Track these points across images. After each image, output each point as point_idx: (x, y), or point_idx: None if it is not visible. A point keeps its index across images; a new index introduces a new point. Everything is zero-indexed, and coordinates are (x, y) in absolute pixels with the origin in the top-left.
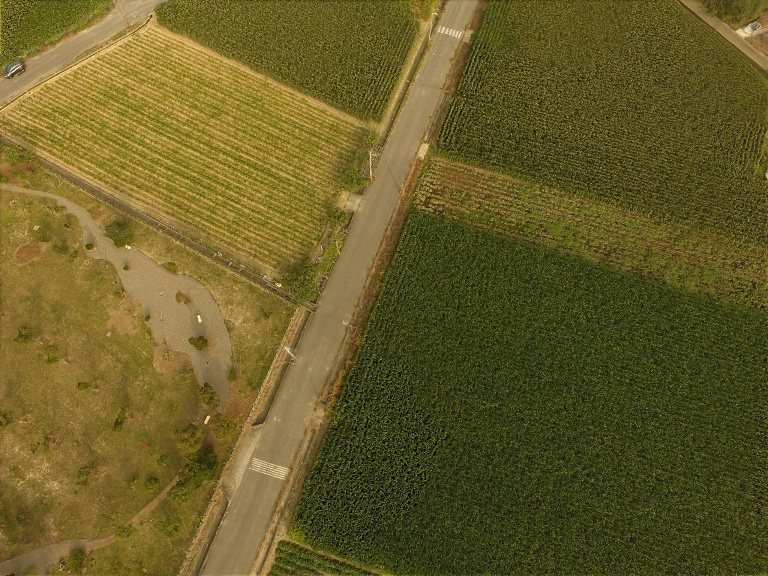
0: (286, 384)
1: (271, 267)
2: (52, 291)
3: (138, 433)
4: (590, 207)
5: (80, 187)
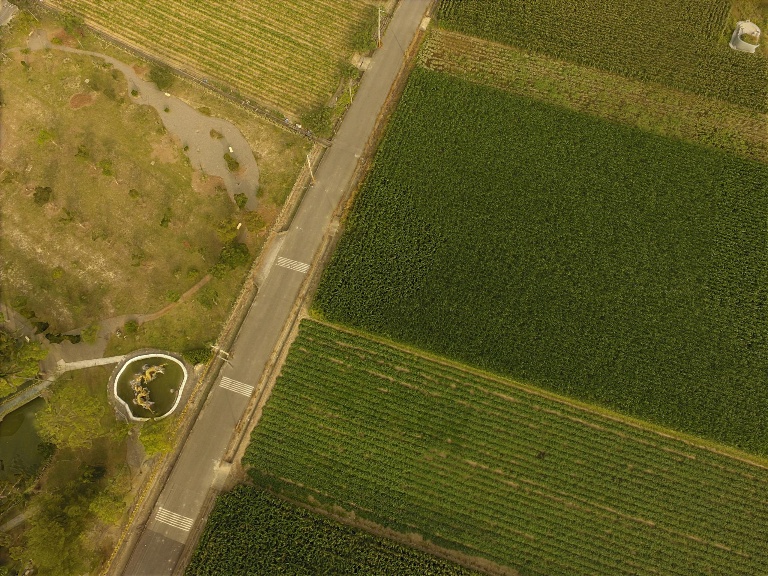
0: (306, 202)
1: (292, 113)
2: (103, 129)
3: (180, 237)
4: (572, 68)
5: (124, 48)
